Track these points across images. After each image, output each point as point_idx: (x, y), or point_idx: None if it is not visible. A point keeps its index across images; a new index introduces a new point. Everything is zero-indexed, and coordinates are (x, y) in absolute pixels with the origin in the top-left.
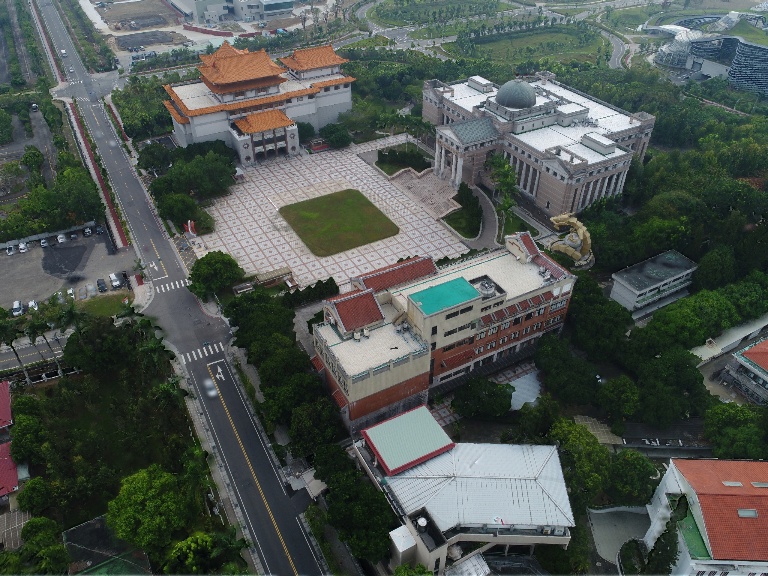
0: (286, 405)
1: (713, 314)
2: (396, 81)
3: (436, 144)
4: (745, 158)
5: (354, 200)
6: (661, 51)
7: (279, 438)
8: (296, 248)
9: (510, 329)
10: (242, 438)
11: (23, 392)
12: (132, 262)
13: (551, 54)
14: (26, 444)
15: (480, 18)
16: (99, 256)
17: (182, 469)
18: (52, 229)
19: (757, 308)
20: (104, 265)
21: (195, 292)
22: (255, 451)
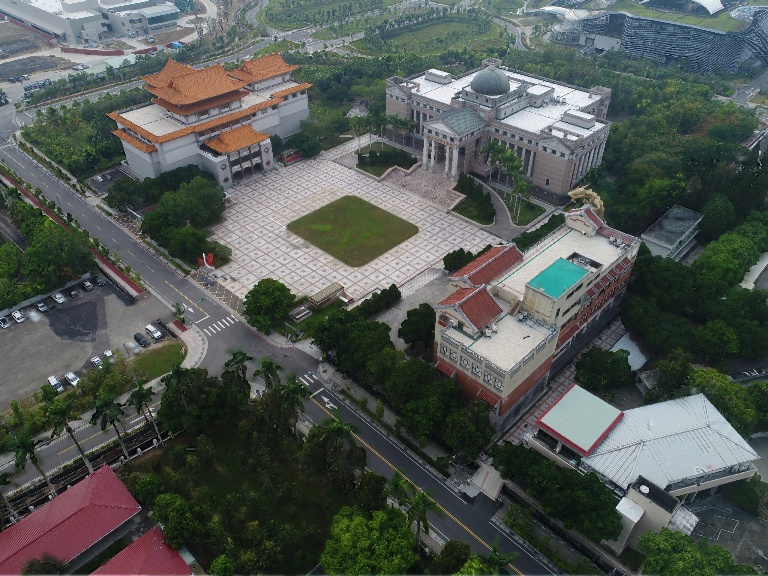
0: (436, 416)
1: (745, 254)
2: (335, 83)
3: (424, 139)
4: (683, 117)
5: (357, 206)
6: (555, 31)
7: (427, 451)
8: (328, 263)
9: (597, 299)
10: (391, 461)
11: (130, 472)
12: (160, 309)
13: (457, 43)
14: (188, 525)
15: (373, 14)
16: (117, 309)
17: (379, 504)
18: (48, 289)
19: (767, 243)
20: (129, 318)
21: (259, 326)
22: (411, 470)
